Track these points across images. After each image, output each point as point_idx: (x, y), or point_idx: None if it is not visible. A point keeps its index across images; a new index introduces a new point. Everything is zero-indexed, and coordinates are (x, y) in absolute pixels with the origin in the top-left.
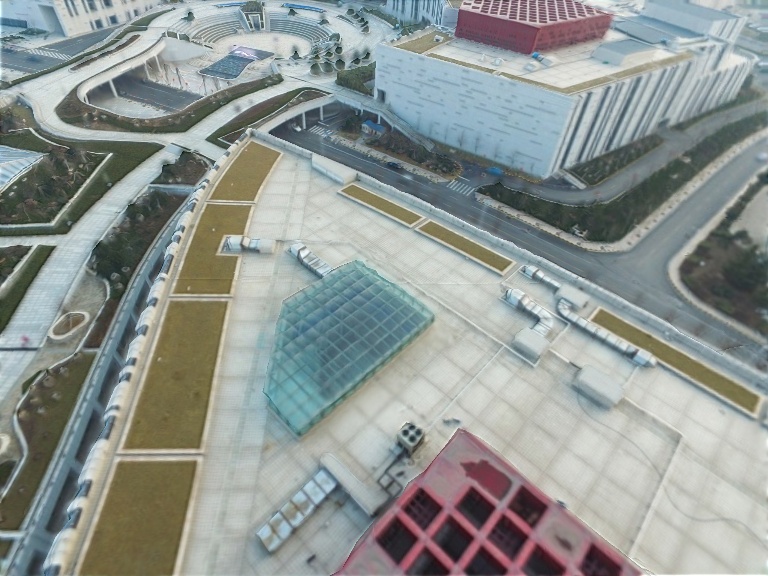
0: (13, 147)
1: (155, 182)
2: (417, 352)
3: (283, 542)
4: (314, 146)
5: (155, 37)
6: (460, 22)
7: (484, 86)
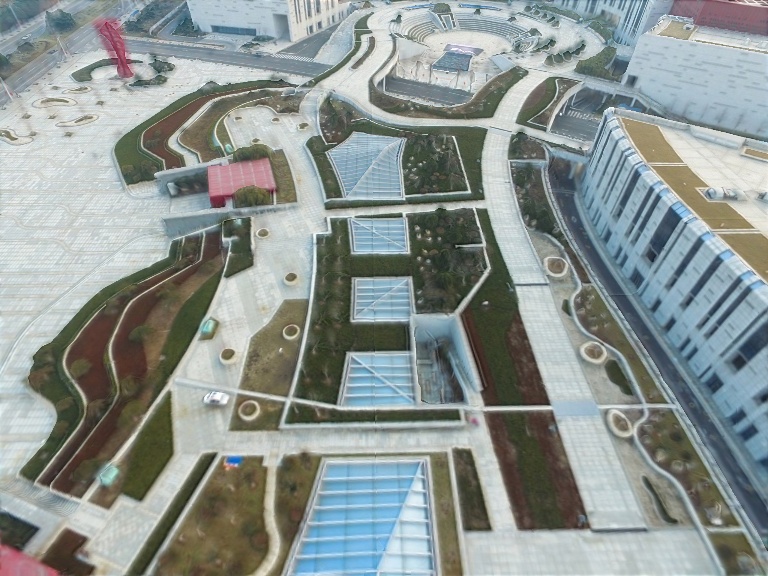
0: (369, 133)
1: (512, 158)
2: None
3: None
4: (585, 128)
5: (387, 38)
6: (704, 11)
7: (763, 66)
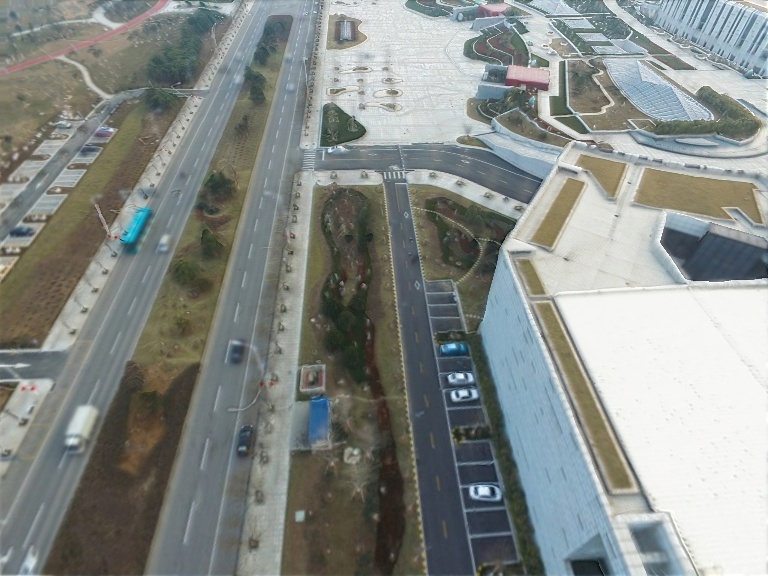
0: None
1: (622, 6)
2: None
3: None
4: None
5: None
6: None
7: None
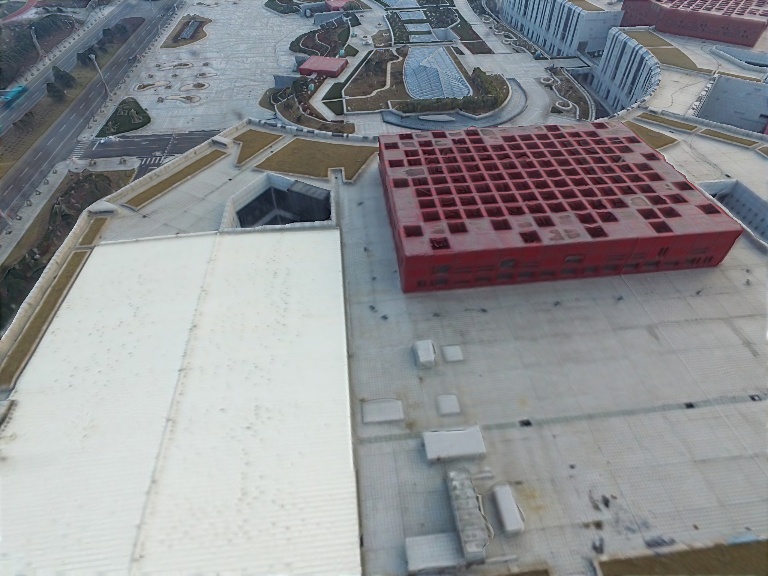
0: None
1: None
2: None
3: None
4: None
5: None
6: None
7: None
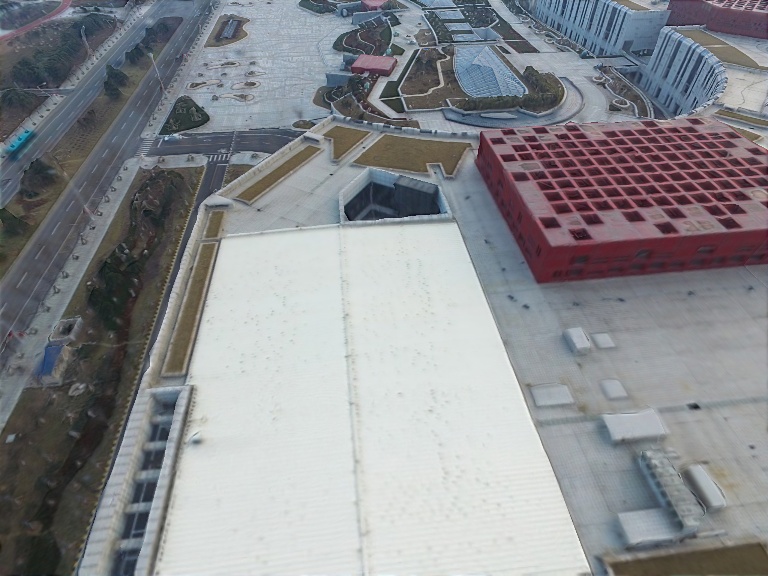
0: None
1: None
2: None
3: (657, 3)
4: None
5: None
6: None
7: None
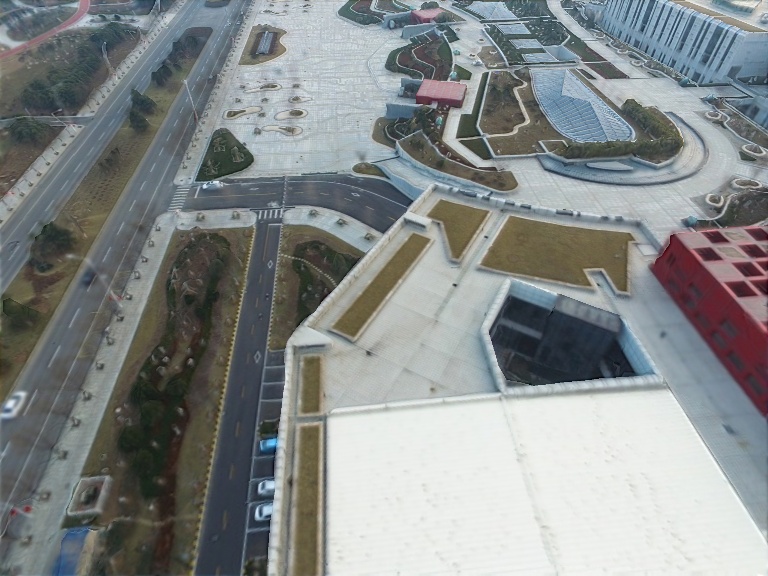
0: None
1: (565, 7)
2: (762, 6)
3: None
4: None
5: None
6: None
7: None
